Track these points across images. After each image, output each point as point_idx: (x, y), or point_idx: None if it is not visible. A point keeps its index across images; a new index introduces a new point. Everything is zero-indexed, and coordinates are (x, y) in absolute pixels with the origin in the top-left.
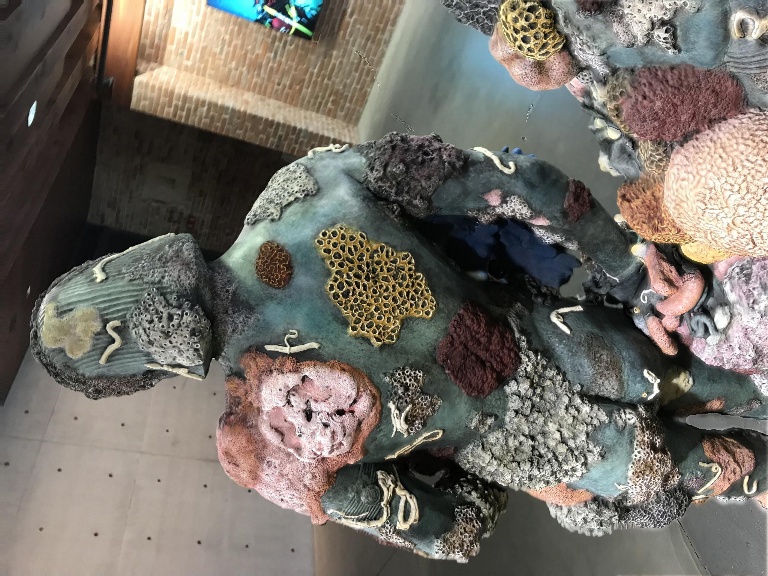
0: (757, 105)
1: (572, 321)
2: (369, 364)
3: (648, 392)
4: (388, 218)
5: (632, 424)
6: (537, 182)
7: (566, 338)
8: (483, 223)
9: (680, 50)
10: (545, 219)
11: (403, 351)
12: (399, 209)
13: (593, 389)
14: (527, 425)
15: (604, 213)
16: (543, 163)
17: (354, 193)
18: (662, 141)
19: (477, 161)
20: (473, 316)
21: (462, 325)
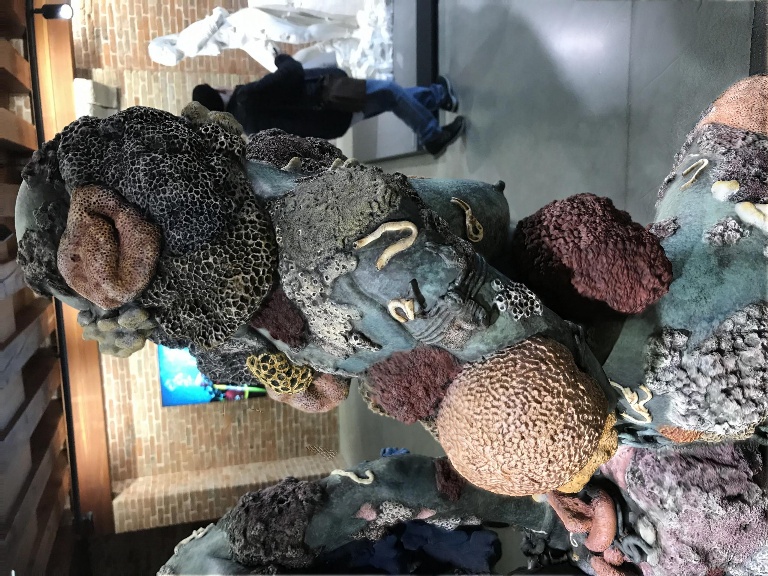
0: (466, 361)
1: None
2: None
3: None
4: None
5: None
6: (400, 479)
7: None
8: (375, 540)
9: (379, 346)
10: (428, 510)
11: None
12: (276, 569)
13: None
14: None
15: None
16: (400, 457)
17: (223, 575)
18: (427, 417)
19: (335, 485)
20: None
21: None
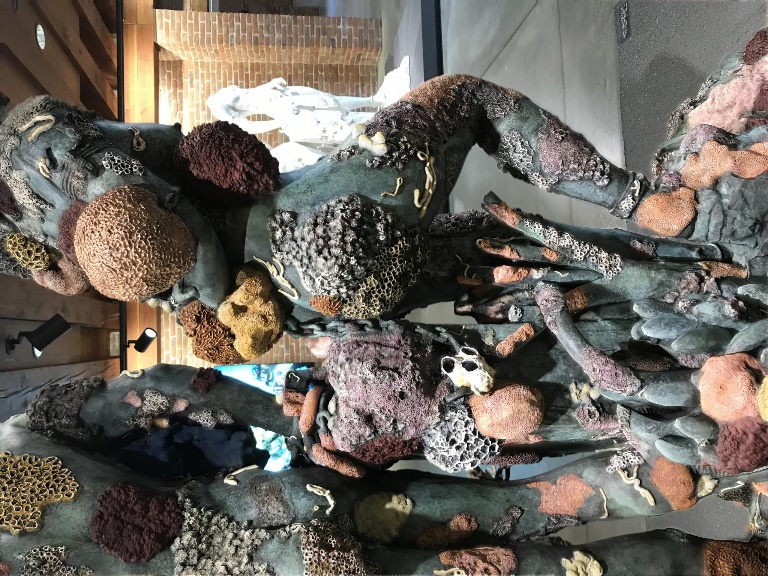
0: None
1: (242, 476)
2: (2, 549)
3: (321, 505)
4: (39, 439)
5: (297, 533)
6: (163, 375)
7: (234, 489)
8: (146, 428)
9: (52, 205)
10: (181, 400)
11: (50, 536)
12: (53, 432)
13: (263, 521)
14: (195, 573)
15: (240, 382)
16: None
17: None
18: None
19: (114, 379)
20: (120, 488)
21: (108, 498)
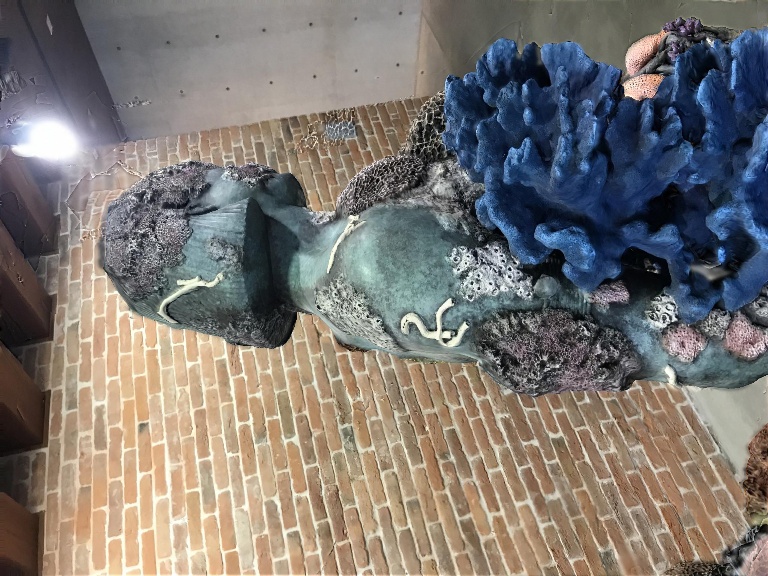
0: None
1: None
2: None
3: None
4: None
5: None
6: None
7: None
8: None
9: None
10: None
11: None
12: None
13: None
14: None
15: None
16: None
17: None
18: None
19: None
20: None
21: None
